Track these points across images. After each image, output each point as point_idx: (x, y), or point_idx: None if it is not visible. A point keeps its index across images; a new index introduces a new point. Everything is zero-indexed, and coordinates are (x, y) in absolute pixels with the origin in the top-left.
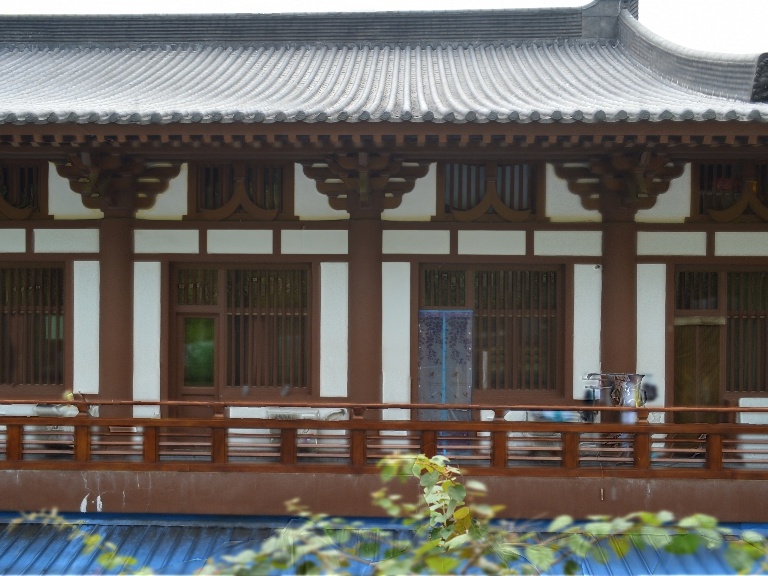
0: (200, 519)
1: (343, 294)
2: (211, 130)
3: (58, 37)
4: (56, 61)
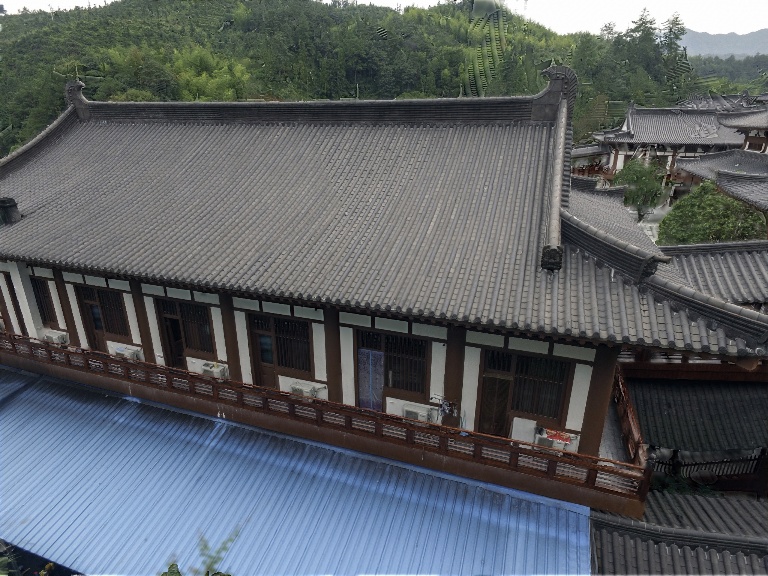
0: (261, 428)
1: (323, 338)
2: (238, 291)
3: (224, 117)
4: (222, 138)
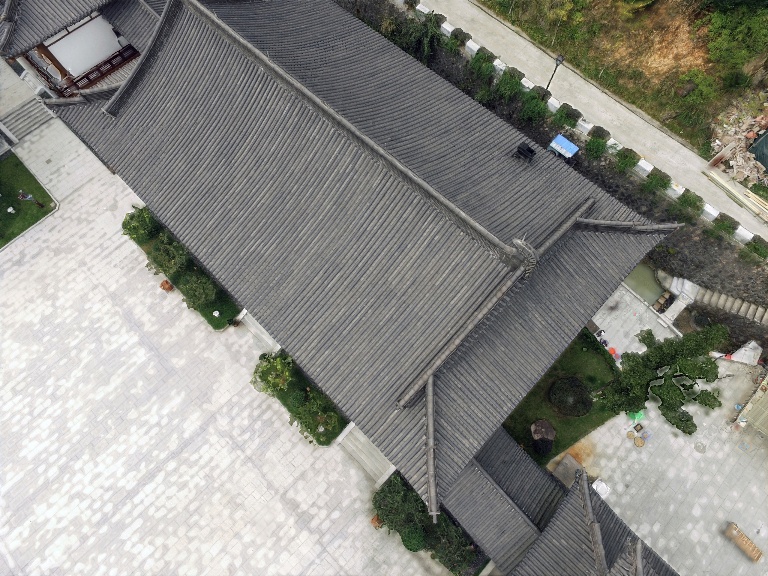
0: None
1: None
2: None
3: None
4: None
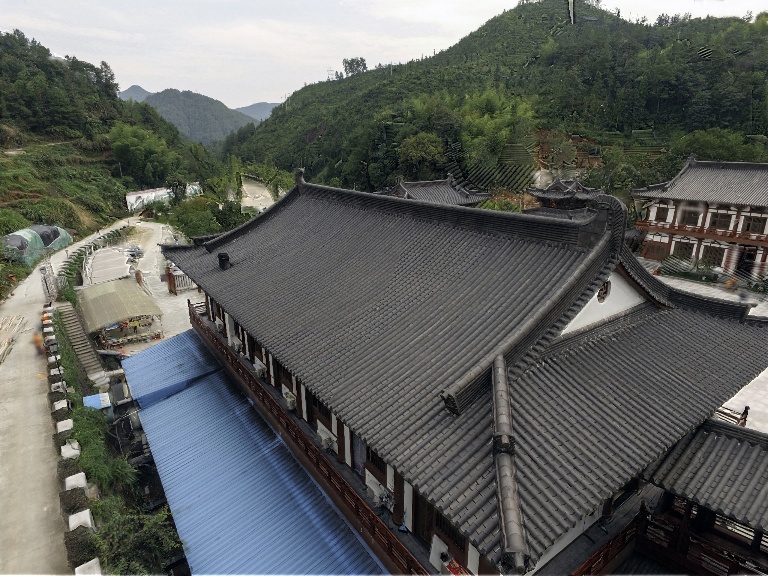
0: None
1: None
2: None
3: (366, 204)
4: None
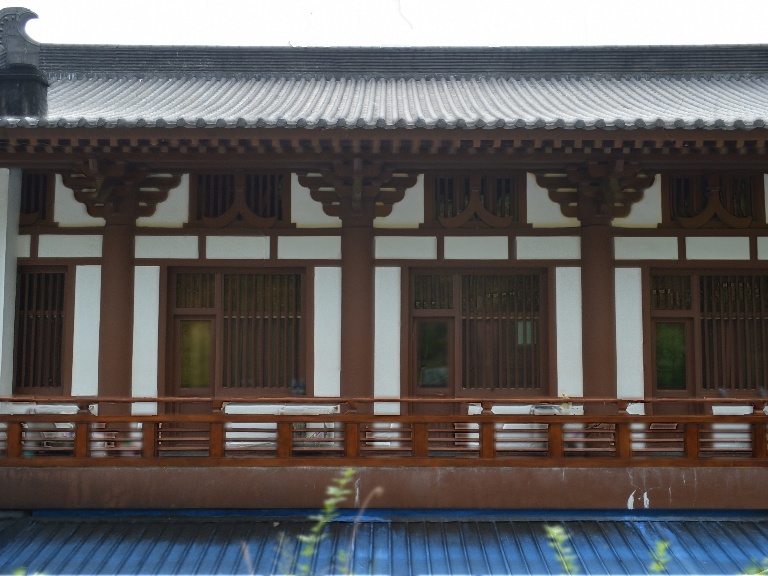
0: (744, 514)
1: None
2: None
3: (344, 68)
4: (356, 89)
